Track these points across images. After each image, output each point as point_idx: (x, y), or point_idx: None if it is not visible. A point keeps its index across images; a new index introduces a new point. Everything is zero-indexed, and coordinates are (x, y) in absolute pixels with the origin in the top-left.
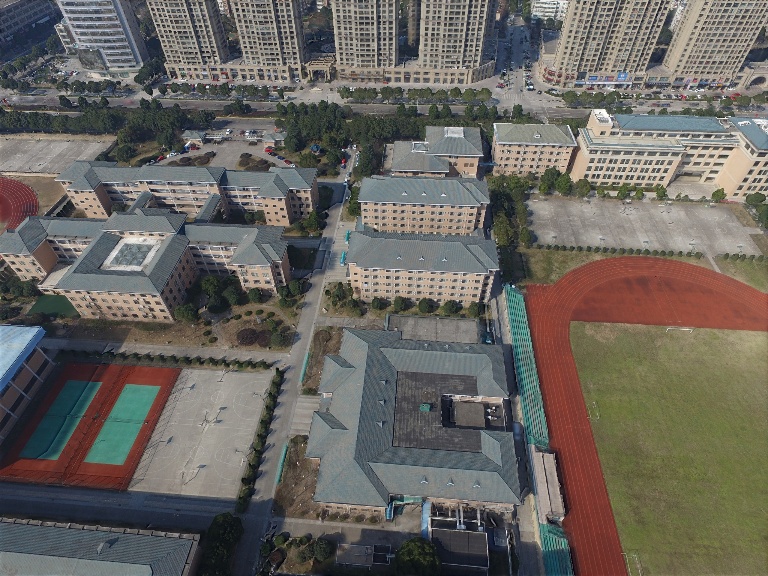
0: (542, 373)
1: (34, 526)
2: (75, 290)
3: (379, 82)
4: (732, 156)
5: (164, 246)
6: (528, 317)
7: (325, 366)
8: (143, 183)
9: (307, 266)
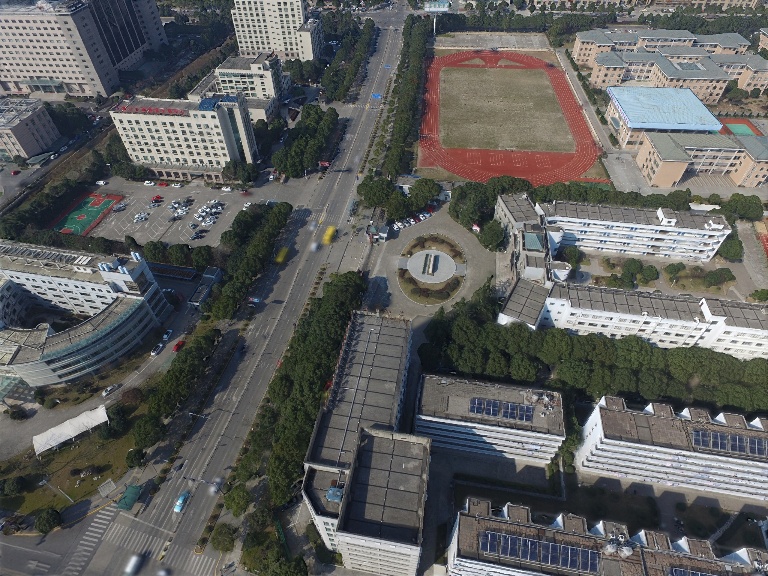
0: None
1: None
2: (681, 78)
3: None
4: None
5: (708, 62)
6: None
7: None
8: (644, 40)
9: None
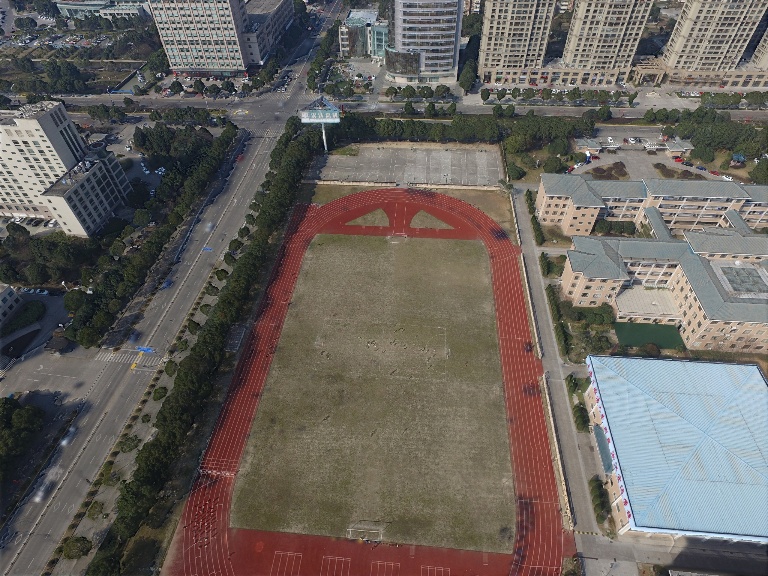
0: None
1: None
2: (735, 321)
3: (714, 86)
4: None
5: None
6: None
7: None
8: (657, 198)
9: None
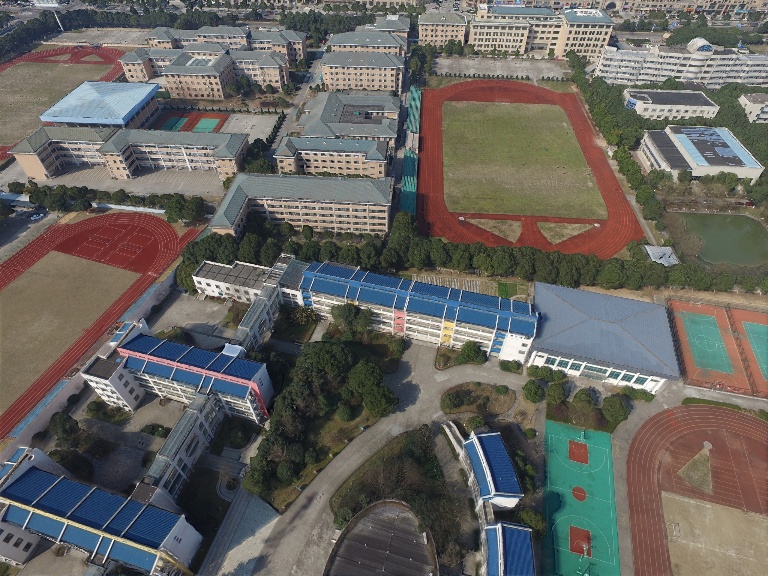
0: (423, 116)
1: (176, 131)
2: (172, 73)
3: None
4: (561, 32)
5: None
6: (422, 99)
7: (308, 102)
8: (200, 37)
9: (299, 80)
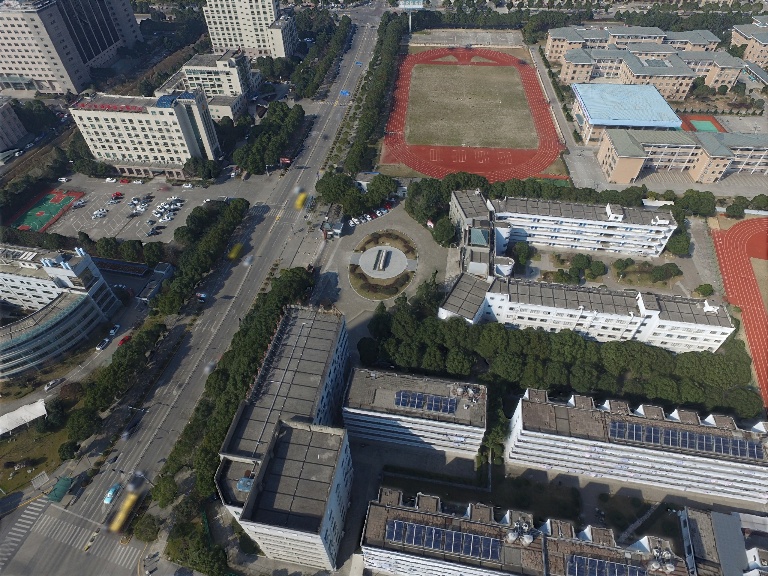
0: None
1: None
2: (647, 75)
3: None
4: None
5: None
6: None
7: None
8: (615, 37)
9: None
